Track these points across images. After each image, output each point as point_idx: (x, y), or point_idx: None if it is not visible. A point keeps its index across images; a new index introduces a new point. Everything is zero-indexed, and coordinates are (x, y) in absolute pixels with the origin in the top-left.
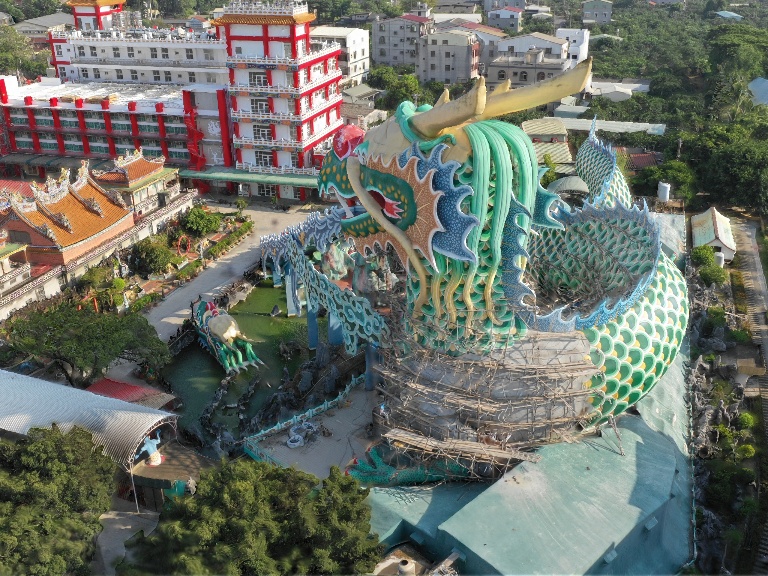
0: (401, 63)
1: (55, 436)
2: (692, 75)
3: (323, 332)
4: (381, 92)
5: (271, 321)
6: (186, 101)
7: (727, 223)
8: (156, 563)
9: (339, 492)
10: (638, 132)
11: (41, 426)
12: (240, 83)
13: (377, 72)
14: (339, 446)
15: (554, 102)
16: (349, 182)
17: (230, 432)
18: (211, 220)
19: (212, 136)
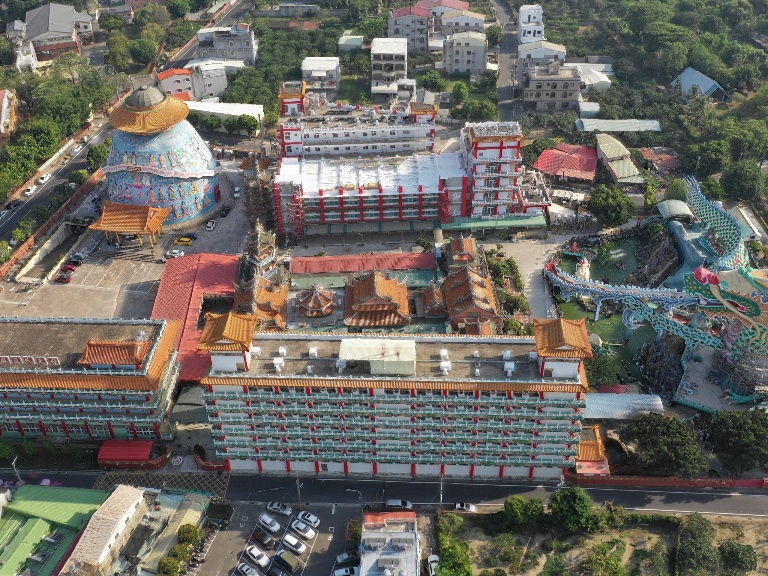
0: (415, 49)
1: (658, 419)
2: (614, 35)
3: (621, 327)
4: (441, 96)
5: (595, 327)
6: (441, 184)
7: (746, 215)
8: (731, 451)
9: (761, 414)
10: (649, 132)
11: (619, 414)
12: (482, 172)
13: (429, 77)
14: (705, 390)
15: (574, 100)
16: (713, 295)
17: (642, 391)
18: (506, 266)
19: (454, 200)
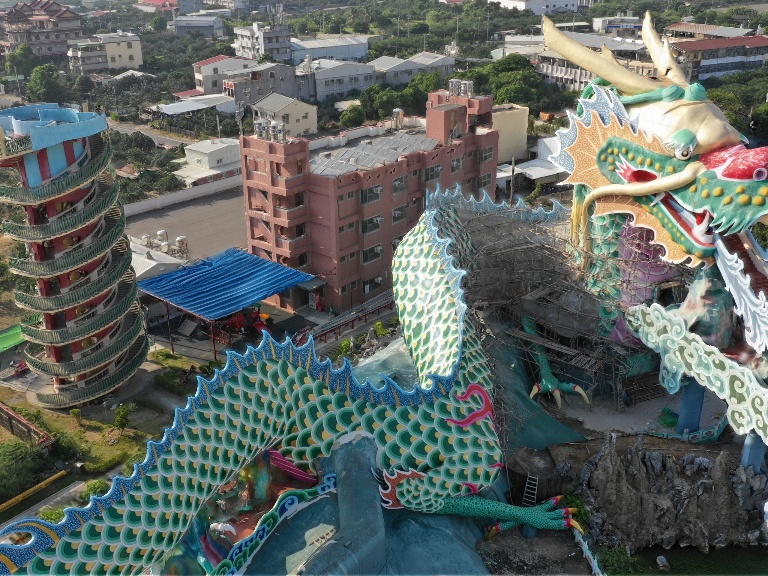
0: None
1: None
2: None
3: None
4: None
5: None
6: None
7: None
8: None
9: None
10: None
11: None
12: None
13: None
14: None
15: None
16: None
17: None
18: None
19: None
